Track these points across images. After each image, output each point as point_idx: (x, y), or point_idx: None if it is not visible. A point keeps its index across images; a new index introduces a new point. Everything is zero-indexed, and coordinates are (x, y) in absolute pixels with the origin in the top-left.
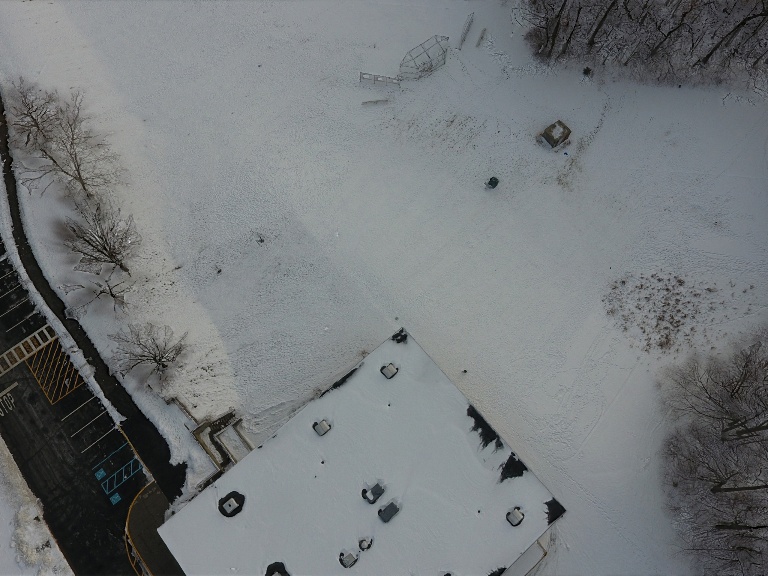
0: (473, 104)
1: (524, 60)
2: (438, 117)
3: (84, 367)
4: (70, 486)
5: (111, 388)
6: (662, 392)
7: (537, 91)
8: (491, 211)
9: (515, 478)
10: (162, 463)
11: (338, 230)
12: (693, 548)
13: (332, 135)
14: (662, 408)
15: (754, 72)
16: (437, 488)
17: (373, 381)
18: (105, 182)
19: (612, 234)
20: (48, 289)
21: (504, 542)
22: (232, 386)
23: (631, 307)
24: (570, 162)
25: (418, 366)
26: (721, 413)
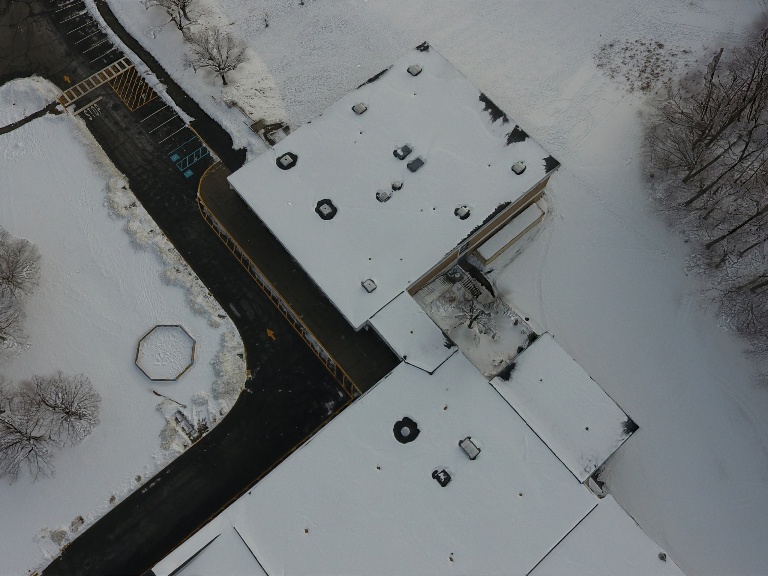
0: None
1: None
2: None
3: (157, 85)
4: (150, 166)
5: (181, 99)
6: (643, 118)
7: None
8: None
9: (519, 142)
10: (226, 148)
11: None
12: (665, 209)
13: None
14: (643, 128)
15: None
16: (455, 149)
17: (401, 77)
18: None
19: (602, 11)
20: (124, 32)
21: (510, 185)
22: (281, 106)
23: (618, 63)
24: None
25: (438, 67)
26: (692, 125)
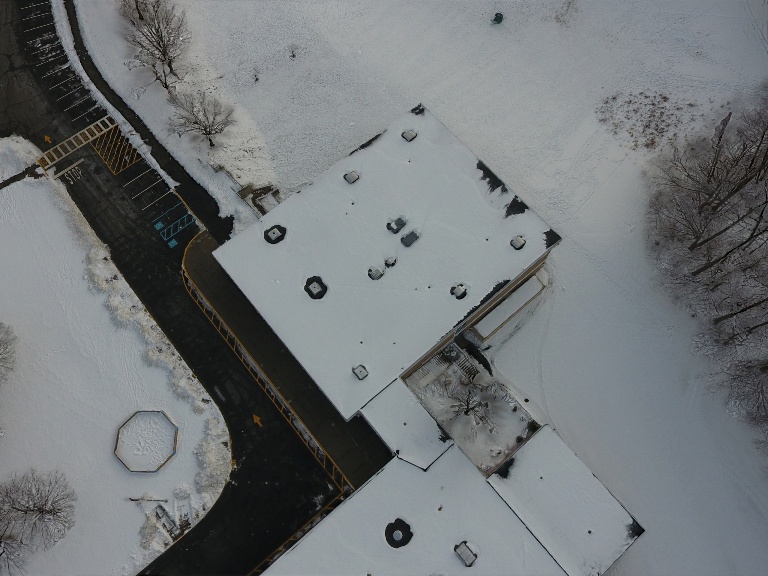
0: None
1: None
2: None
3: (142, 146)
4: (133, 235)
5: (166, 162)
6: (647, 179)
7: None
8: (496, 41)
9: (518, 215)
10: (212, 216)
11: (361, 49)
12: (671, 282)
13: None
14: (647, 190)
15: None
16: (451, 222)
17: (395, 143)
18: None
19: (604, 61)
20: (107, 88)
21: (509, 261)
22: (270, 167)
23: (621, 117)
24: (567, 4)
25: (434, 132)
26: (698, 188)
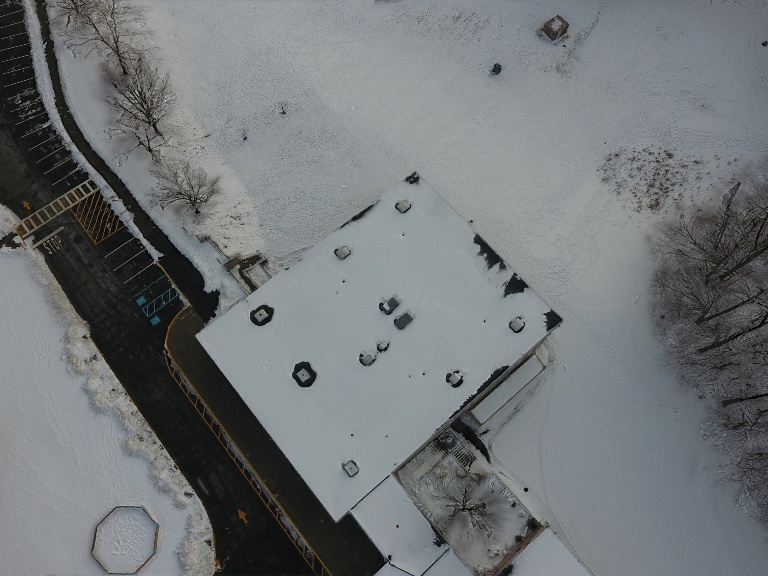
0: (478, 2)
1: None
2: (445, 13)
3: (124, 213)
4: (114, 311)
5: (149, 230)
6: (652, 244)
7: None
8: (495, 94)
9: (517, 294)
10: (197, 291)
11: (354, 104)
12: (678, 363)
13: (347, 28)
14: (651, 257)
15: None
16: (447, 302)
17: (388, 215)
18: None
19: (607, 115)
20: (89, 150)
21: (507, 345)
22: (258, 234)
23: (624, 176)
24: (568, 53)
25: (429, 203)
26: (705, 257)
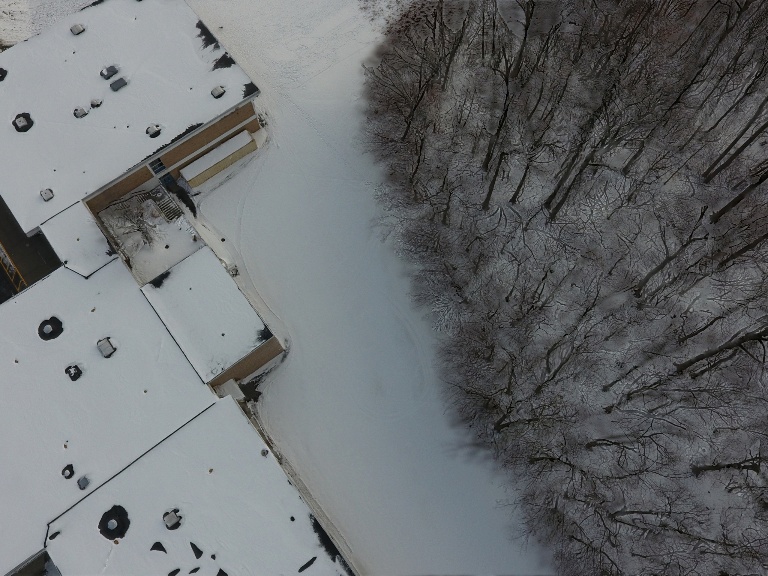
0: None
1: None
2: None
3: None
4: None
5: None
6: None
7: None
8: None
9: (224, 68)
10: None
11: None
12: (372, 141)
13: None
14: None
15: None
16: (161, 72)
17: (125, 2)
18: None
19: None
20: None
21: (206, 107)
22: (28, 29)
23: (382, 6)
24: None
25: None
26: (426, 66)
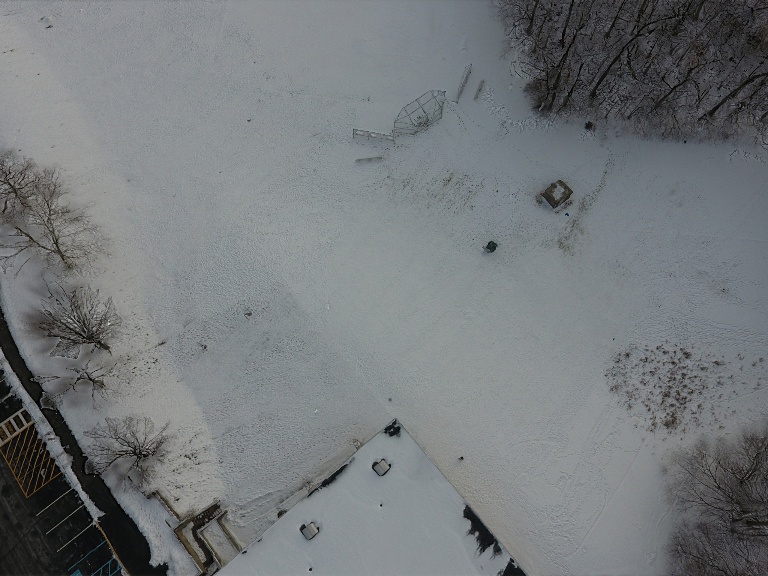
0: (471, 161)
1: (524, 114)
2: (434, 175)
3: (61, 456)
4: None
5: (89, 480)
6: (668, 477)
7: (537, 147)
8: (489, 278)
9: None
10: (142, 564)
11: (329, 302)
12: None
13: (324, 195)
14: (668, 496)
15: (762, 126)
16: None
17: (364, 479)
18: (85, 254)
19: (615, 302)
20: (24, 369)
21: None
22: (217, 474)
23: (635, 382)
24: (571, 224)
25: (412, 462)
26: (731, 504)
